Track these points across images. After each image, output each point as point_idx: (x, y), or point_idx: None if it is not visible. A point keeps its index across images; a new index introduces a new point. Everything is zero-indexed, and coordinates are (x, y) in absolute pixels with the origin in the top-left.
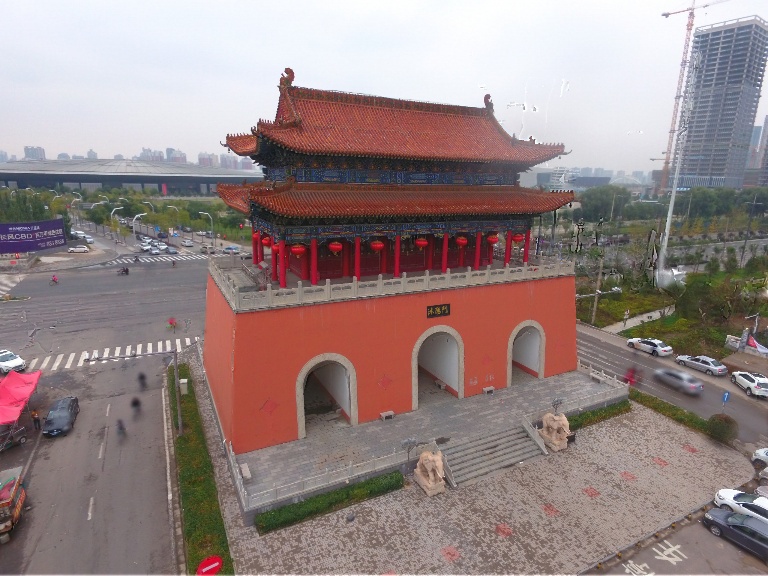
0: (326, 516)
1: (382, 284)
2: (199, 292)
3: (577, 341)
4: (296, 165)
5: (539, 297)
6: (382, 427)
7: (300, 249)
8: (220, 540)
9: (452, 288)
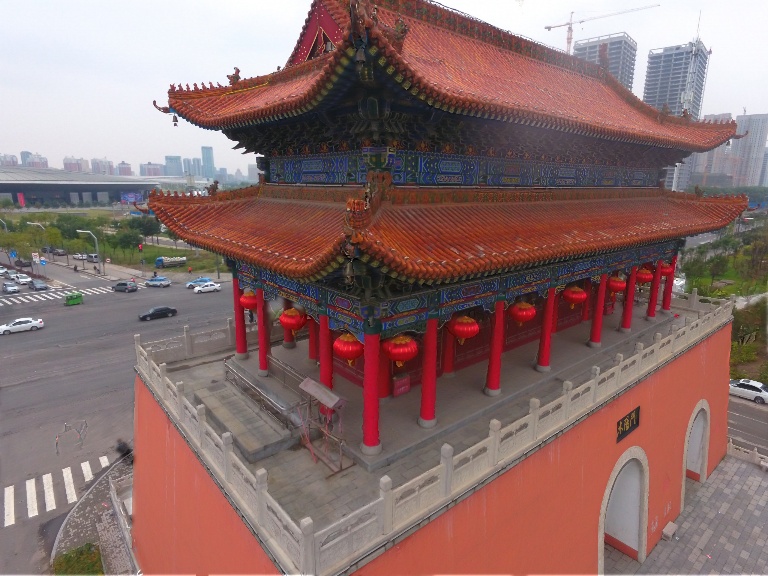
0: None
1: (569, 401)
2: (92, 355)
3: None
4: (388, 144)
5: (708, 361)
6: None
7: (411, 348)
8: None
9: (644, 377)
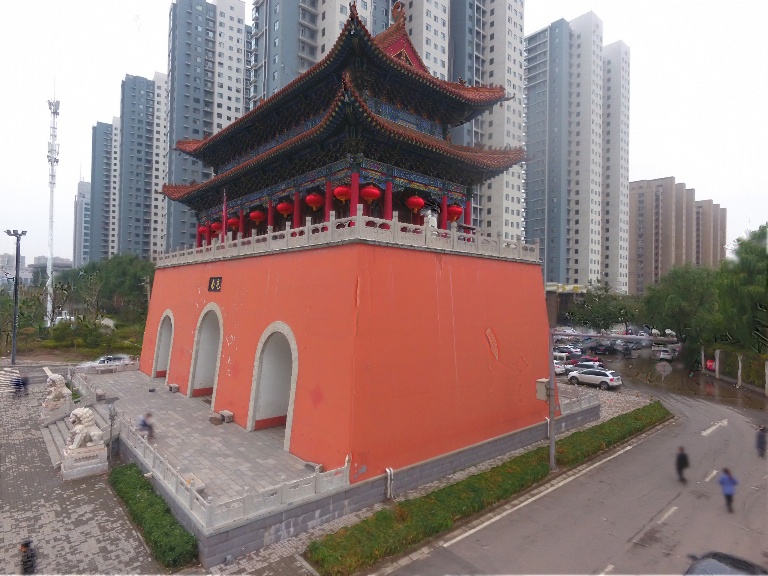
0: None
1: None
2: None
3: None
4: None
5: None
6: None
7: None
8: None
9: None
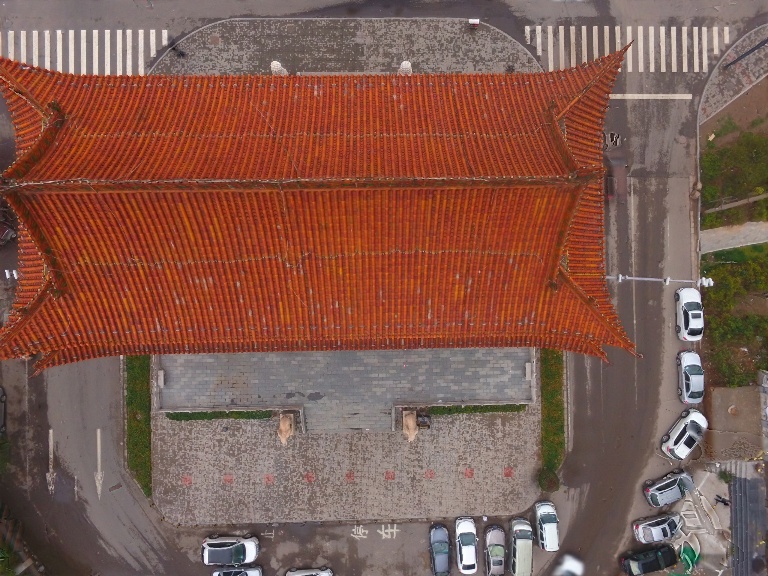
0: (211, 420)
1: None
2: None
3: (628, 252)
4: None
5: None
6: (280, 359)
7: None
8: (144, 419)
9: None
